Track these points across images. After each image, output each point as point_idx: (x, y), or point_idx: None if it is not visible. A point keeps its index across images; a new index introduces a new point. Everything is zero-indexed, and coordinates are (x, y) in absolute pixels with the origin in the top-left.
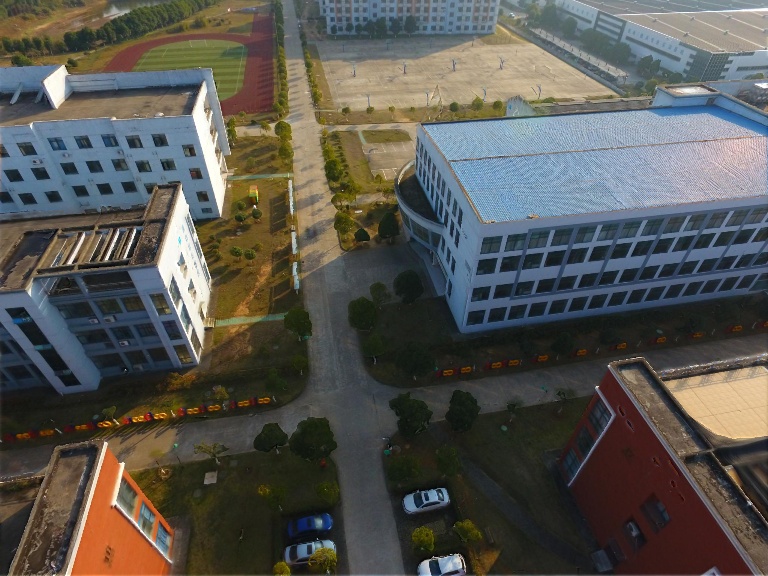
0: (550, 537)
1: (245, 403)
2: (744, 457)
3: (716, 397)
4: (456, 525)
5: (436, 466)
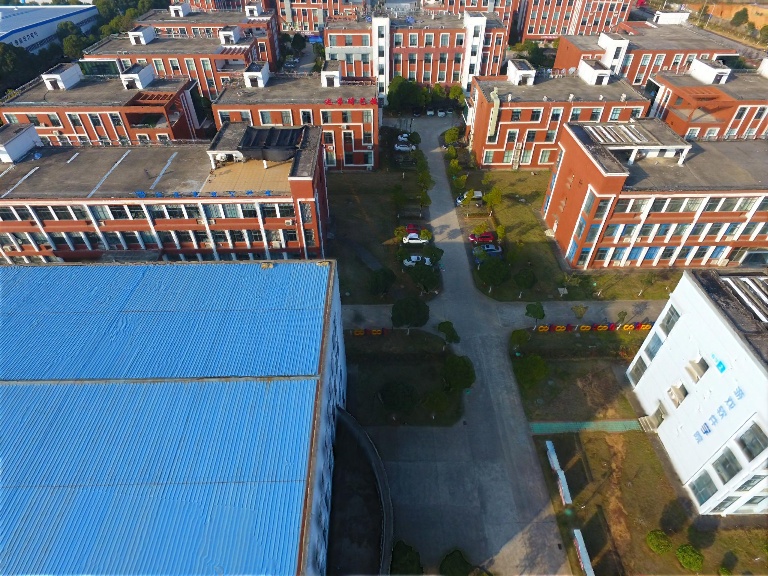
0: (351, 246)
1: (559, 328)
2: (286, 148)
3: (250, 187)
4: (407, 234)
5: (406, 279)
